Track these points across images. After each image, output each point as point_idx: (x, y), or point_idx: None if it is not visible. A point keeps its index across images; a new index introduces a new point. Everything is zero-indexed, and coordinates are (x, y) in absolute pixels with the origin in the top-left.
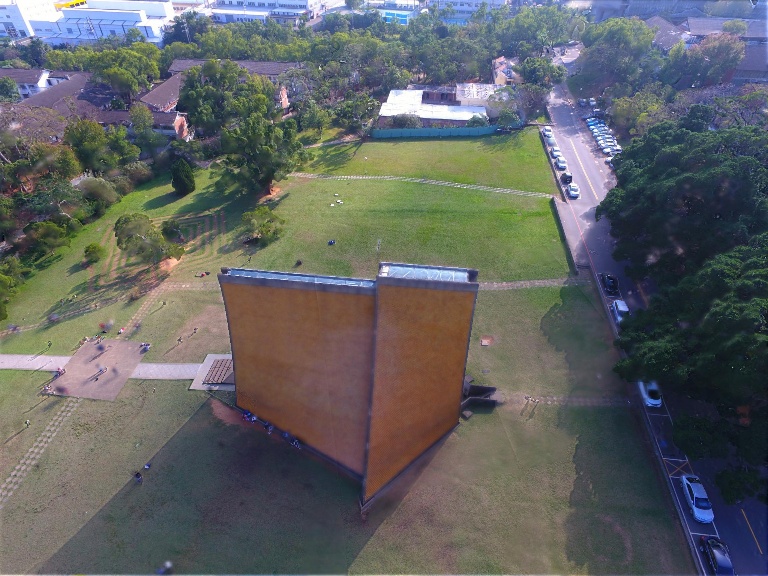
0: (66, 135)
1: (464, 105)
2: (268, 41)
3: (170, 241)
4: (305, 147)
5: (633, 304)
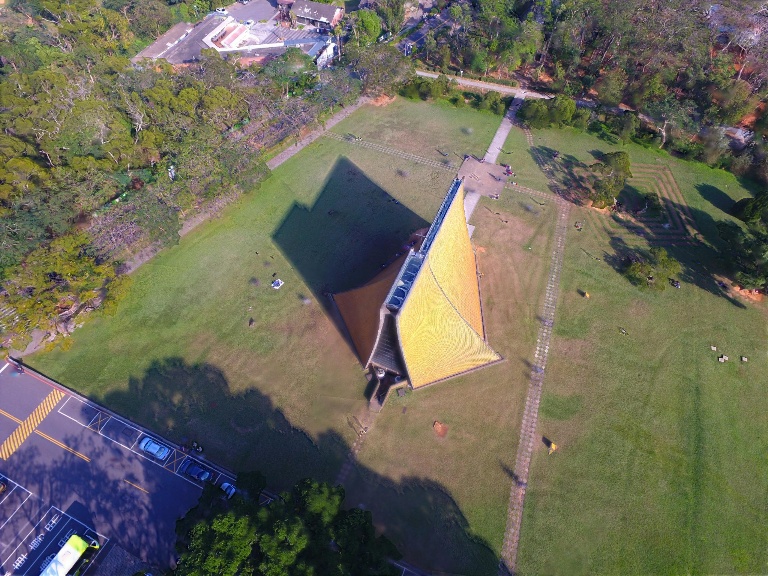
0: None
1: None
2: None
3: (635, 205)
4: None
5: None
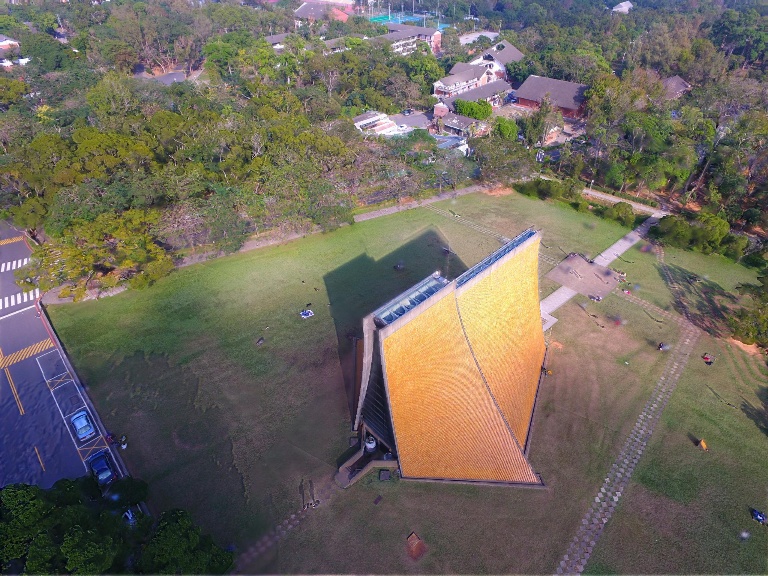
0: None
1: None
2: None
3: None
4: None
5: None
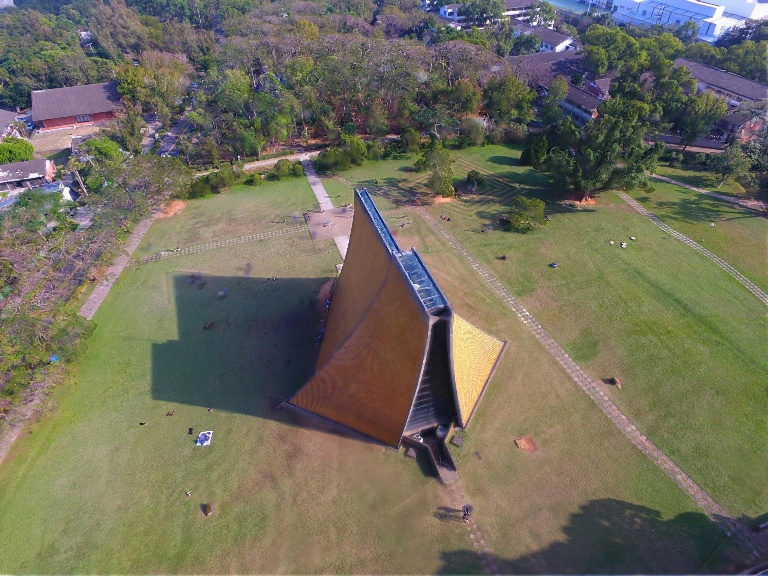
0: (489, 82)
1: None
2: None
3: (465, 187)
4: (685, 185)
5: None
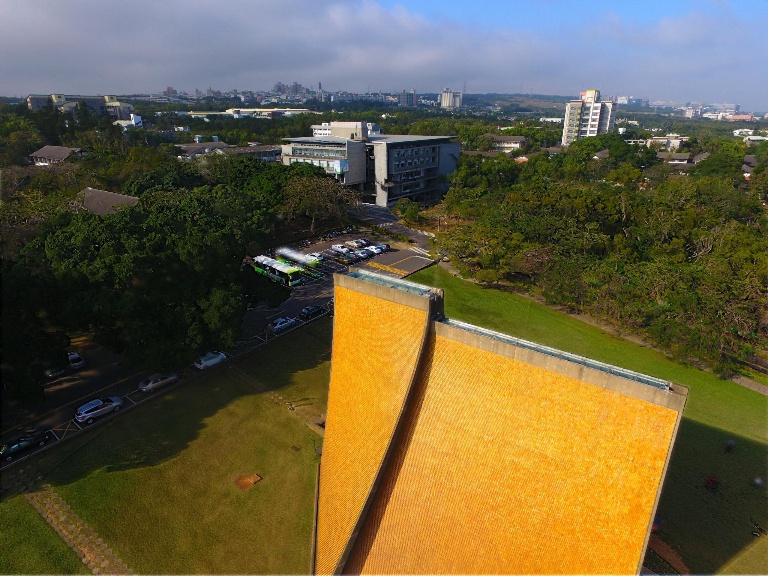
0: None
1: None
2: None
3: None
4: None
5: (63, 416)
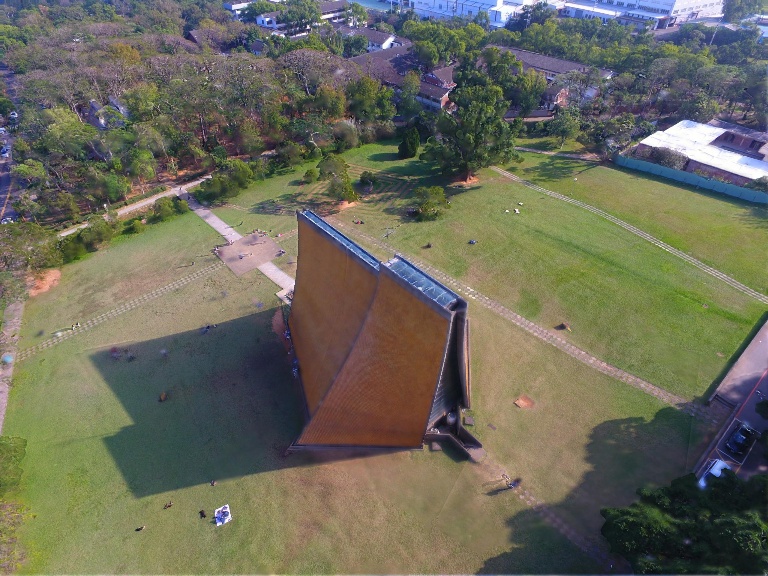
0: (348, 85)
1: (767, 161)
2: (588, 41)
3: (362, 188)
4: (537, 151)
5: None
